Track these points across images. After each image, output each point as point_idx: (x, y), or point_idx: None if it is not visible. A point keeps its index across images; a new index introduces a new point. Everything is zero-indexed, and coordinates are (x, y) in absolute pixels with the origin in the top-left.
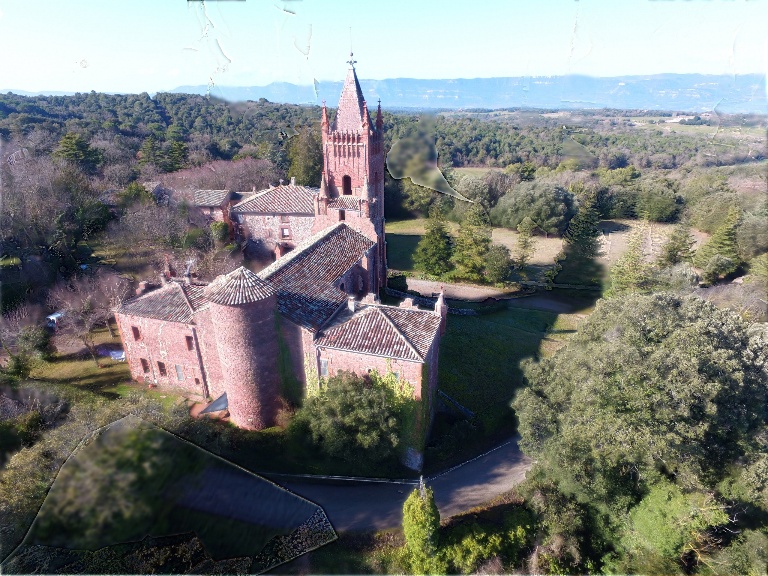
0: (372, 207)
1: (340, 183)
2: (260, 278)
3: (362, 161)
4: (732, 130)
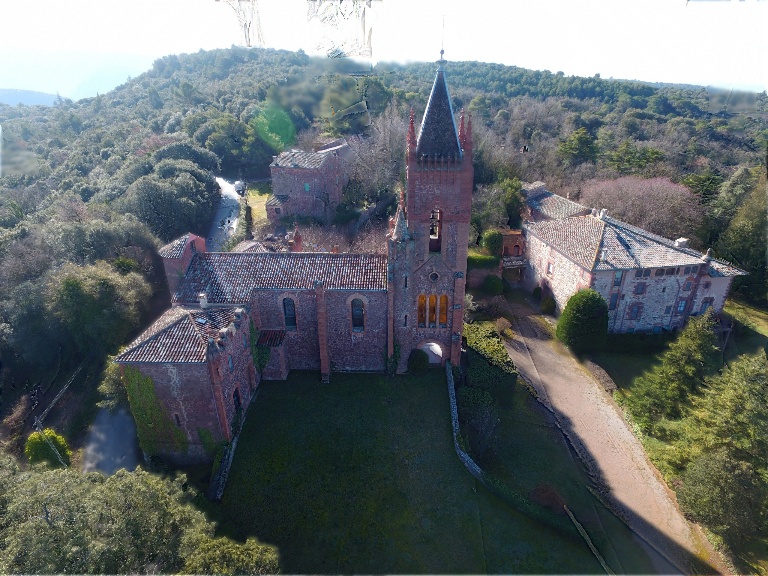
0: (392, 245)
1: None
2: (184, 245)
3: None
4: None
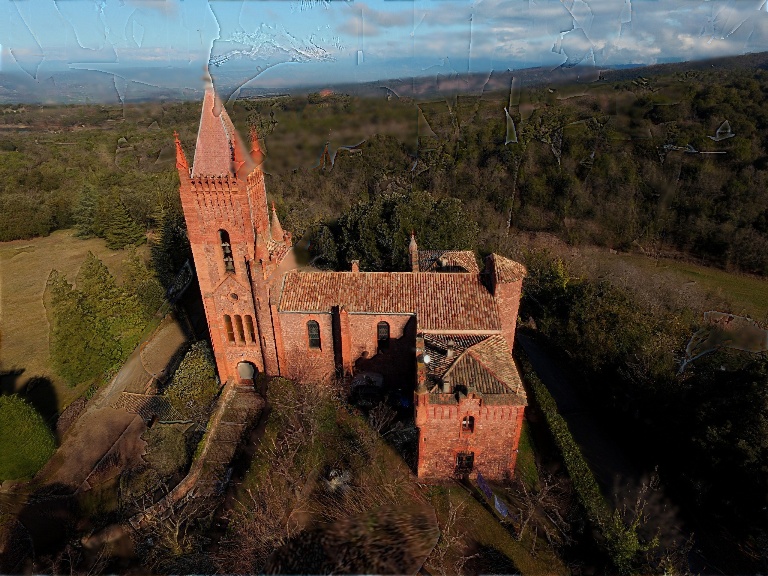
0: None
1: None
2: None
3: (263, 197)
4: (70, 129)
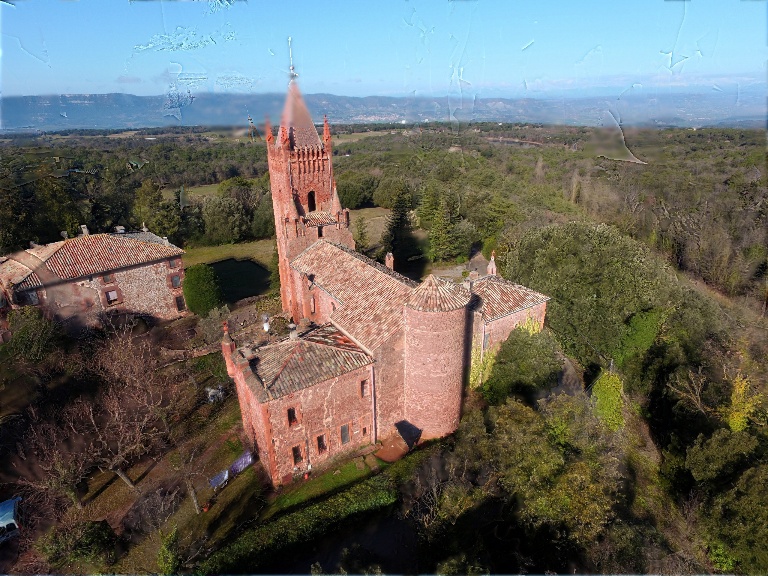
0: (347, 217)
1: (305, 201)
2: None
3: (326, 174)
4: None
